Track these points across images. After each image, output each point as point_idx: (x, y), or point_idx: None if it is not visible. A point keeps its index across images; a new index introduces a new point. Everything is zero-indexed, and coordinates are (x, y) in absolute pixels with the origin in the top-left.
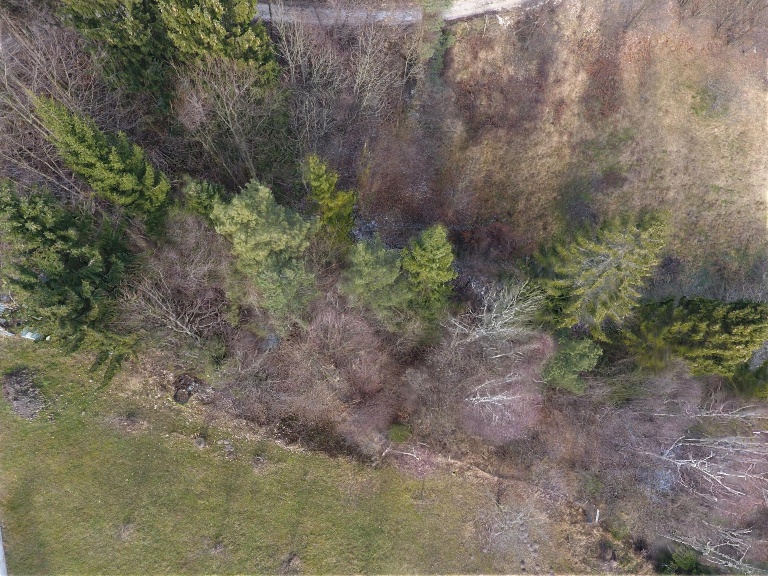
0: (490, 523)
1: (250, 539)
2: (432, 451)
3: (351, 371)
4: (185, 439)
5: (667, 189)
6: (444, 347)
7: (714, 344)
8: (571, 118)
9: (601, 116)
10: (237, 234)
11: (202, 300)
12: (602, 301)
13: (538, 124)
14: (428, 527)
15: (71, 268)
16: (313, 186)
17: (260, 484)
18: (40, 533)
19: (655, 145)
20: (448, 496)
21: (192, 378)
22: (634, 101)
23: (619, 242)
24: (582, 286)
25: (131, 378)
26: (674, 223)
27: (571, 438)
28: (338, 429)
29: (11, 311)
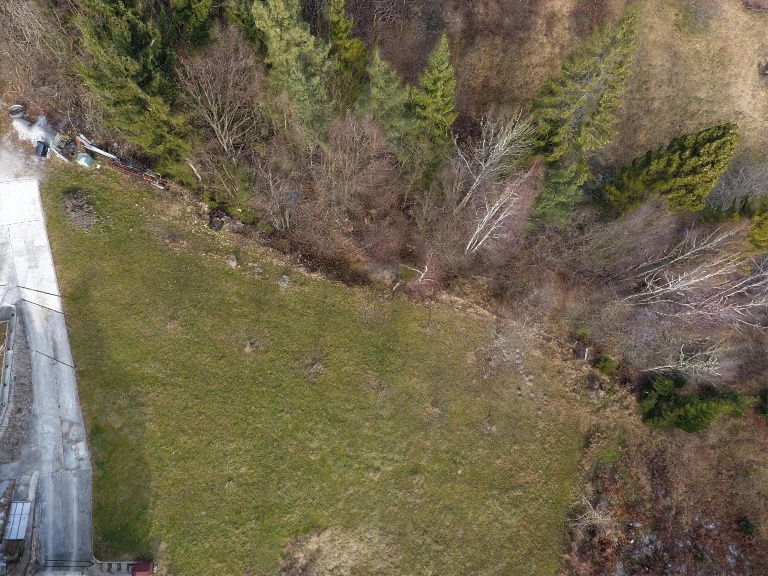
0: (490, 355)
1: (278, 344)
2: (437, 289)
3: (363, 225)
4: (220, 259)
5: (652, 99)
6: (447, 215)
7: (686, 173)
8: (562, 31)
9: (590, 31)
10: (273, 28)
11: (240, 102)
12: (586, 123)
13: (532, 34)
14: (434, 351)
15: (136, 46)
16: (333, 23)
17: (286, 301)
18: (98, 321)
19: (641, 59)
20: (452, 328)
21: (224, 213)
22: (621, 18)
23: (598, 53)
24: (568, 109)
25: (171, 205)
26: (659, 132)
27: (562, 293)
28: (353, 267)
29: (66, 143)
